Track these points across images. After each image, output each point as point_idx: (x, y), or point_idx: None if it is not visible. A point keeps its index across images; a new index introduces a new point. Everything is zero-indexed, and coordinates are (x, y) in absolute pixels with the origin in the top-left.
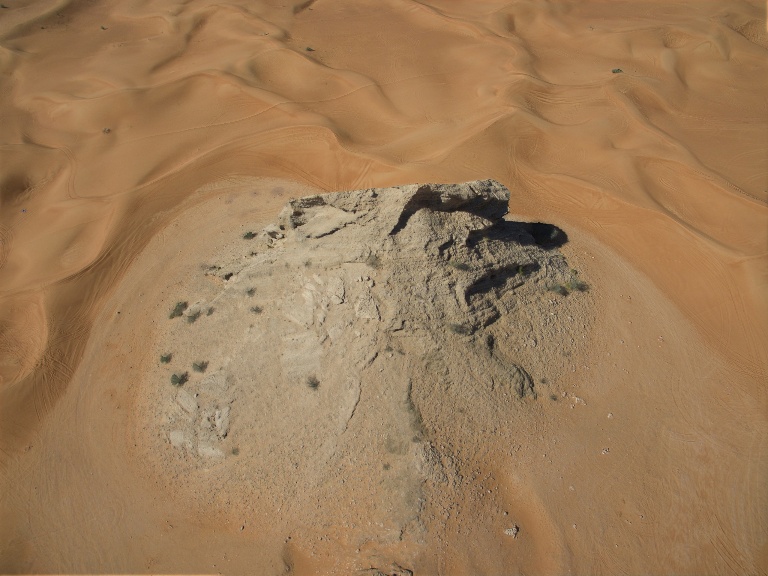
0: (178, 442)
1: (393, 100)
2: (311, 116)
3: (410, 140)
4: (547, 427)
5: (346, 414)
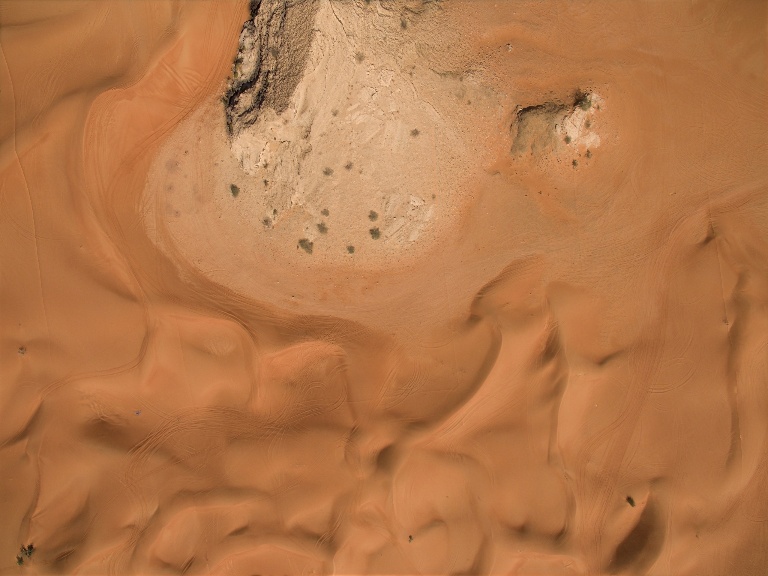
0: (418, 235)
1: (44, 15)
2: (58, 115)
3: (136, 14)
4: (461, 3)
5: (438, 118)
